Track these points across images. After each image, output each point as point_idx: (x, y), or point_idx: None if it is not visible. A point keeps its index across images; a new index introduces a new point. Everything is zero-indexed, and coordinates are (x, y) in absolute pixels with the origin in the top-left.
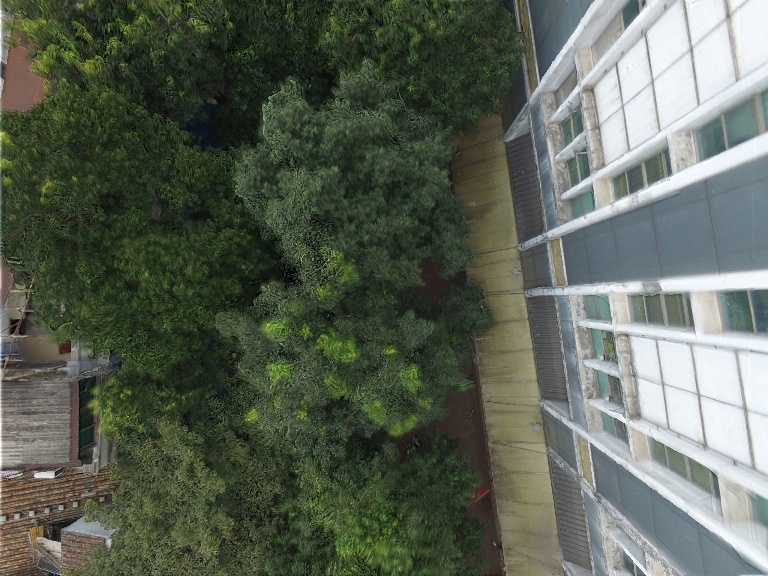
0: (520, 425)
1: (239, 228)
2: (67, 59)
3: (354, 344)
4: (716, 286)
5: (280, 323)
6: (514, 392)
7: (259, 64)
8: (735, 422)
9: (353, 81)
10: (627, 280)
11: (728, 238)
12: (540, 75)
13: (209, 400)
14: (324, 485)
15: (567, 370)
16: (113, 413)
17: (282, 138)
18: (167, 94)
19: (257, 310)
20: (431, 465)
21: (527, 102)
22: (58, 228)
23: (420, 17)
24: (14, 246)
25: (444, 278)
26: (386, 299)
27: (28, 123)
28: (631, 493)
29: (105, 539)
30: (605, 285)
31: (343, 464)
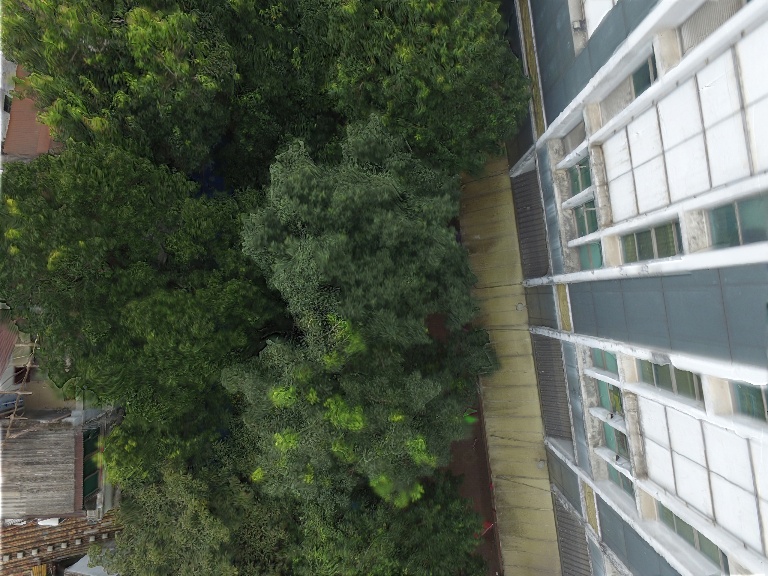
0: (524, 460)
1: (245, 277)
2: (74, 115)
3: (361, 409)
4: (728, 375)
5: (287, 391)
6: (518, 427)
7: (265, 106)
8: (746, 506)
9: (361, 138)
10: (635, 344)
11: (741, 330)
12: (547, 121)
13: (213, 443)
14: (329, 536)
15: (572, 414)
16: (118, 466)
17: (290, 204)
18: (173, 143)
19: (263, 362)
20: (436, 512)
21: (534, 145)
22: (64, 290)
23: (428, 70)
24: (20, 309)
25: None
26: (393, 357)
27: (34, 176)
28: (637, 551)
29: None
30: (613, 344)
31: (348, 513)
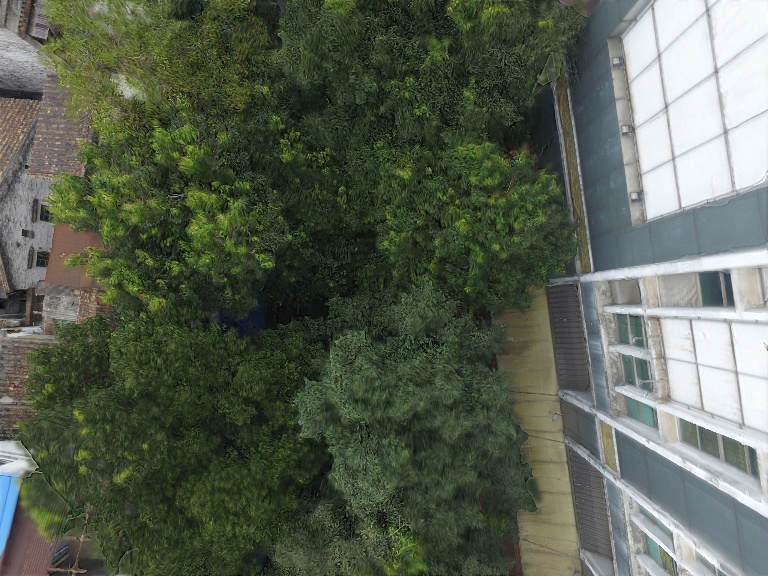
0: (557, 568)
1: (293, 431)
2: (130, 292)
3: None
4: None
5: None
6: (551, 534)
7: None
8: None
9: (419, 317)
10: (698, 538)
11: None
12: (594, 262)
13: None
14: None
15: (615, 550)
16: None
17: (356, 411)
18: None
19: None
20: None
21: (577, 277)
22: None
23: (482, 234)
24: None
25: None
26: (449, 536)
27: (87, 342)
28: None
29: None
30: (670, 522)
31: None
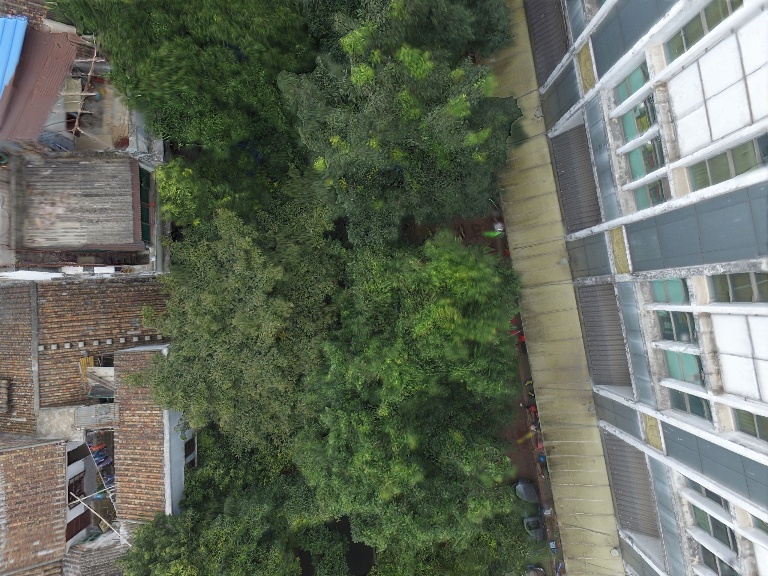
0: (547, 266)
1: None
2: None
3: None
4: None
5: None
6: (540, 235)
7: None
8: None
9: None
10: None
11: None
12: None
13: (258, 211)
14: (379, 263)
15: (598, 175)
16: (178, 183)
17: None
18: None
19: None
20: None
21: None
22: None
23: None
24: None
25: None
26: (440, 52)
27: None
28: (673, 235)
29: (161, 349)
30: (643, 37)
31: None
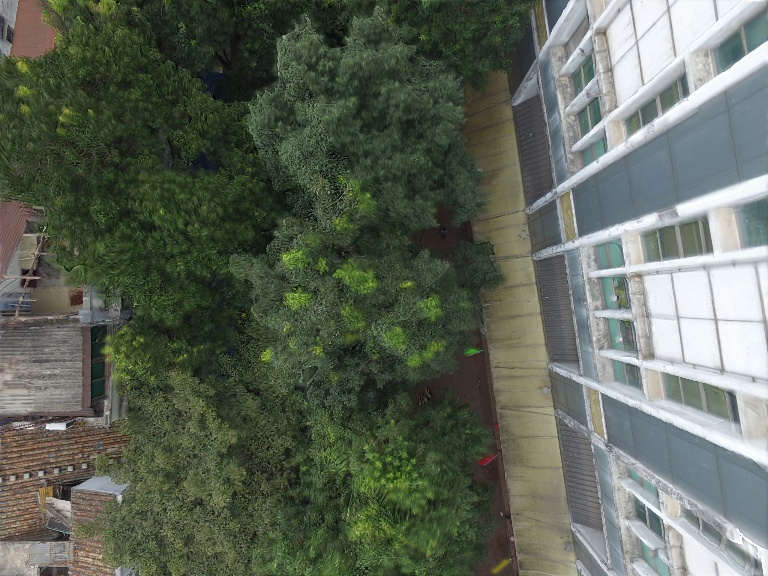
0: (528, 389)
1: (251, 177)
2: None
3: (370, 278)
4: (736, 196)
5: (297, 253)
6: (522, 357)
7: (269, 20)
8: (754, 338)
9: (366, 22)
10: (641, 216)
11: (749, 145)
12: (550, 28)
13: (220, 356)
14: (336, 434)
15: (577, 325)
16: (126, 358)
17: (298, 69)
18: (179, 42)
19: (270, 257)
20: (442, 418)
21: (536, 58)
22: (73, 164)
23: None
24: (29, 181)
25: (457, 224)
26: (400, 240)
27: (40, 67)
28: (645, 435)
29: (116, 495)
30: (618, 226)
31: (355, 415)
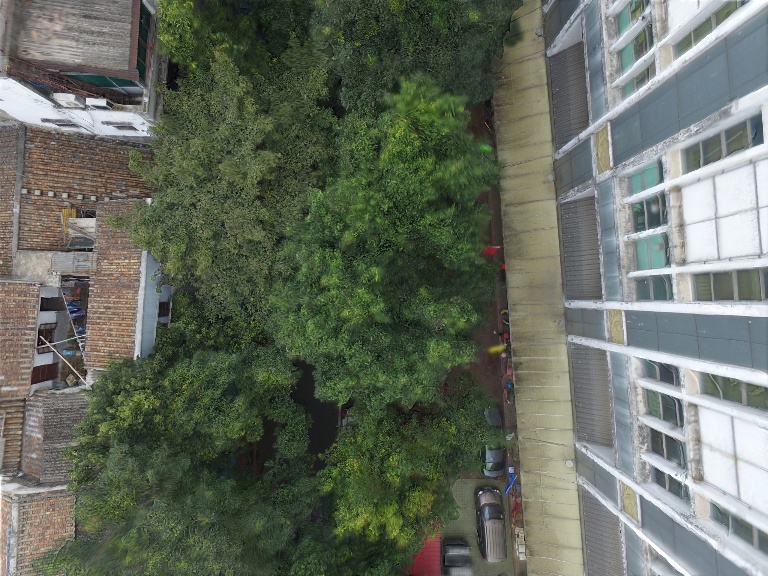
0: (532, 185)
1: None
2: None
3: None
4: None
5: None
6: (529, 155)
7: None
8: None
9: None
10: None
11: None
12: None
13: (255, 73)
14: (369, 122)
15: (590, 79)
16: (178, 10)
17: None
18: None
19: None
20: None
21: None
22: None
23: None
24: None
25: None
26: None
27: None
28: (654, 114)
29: (145, 198)
30: None
31: None
